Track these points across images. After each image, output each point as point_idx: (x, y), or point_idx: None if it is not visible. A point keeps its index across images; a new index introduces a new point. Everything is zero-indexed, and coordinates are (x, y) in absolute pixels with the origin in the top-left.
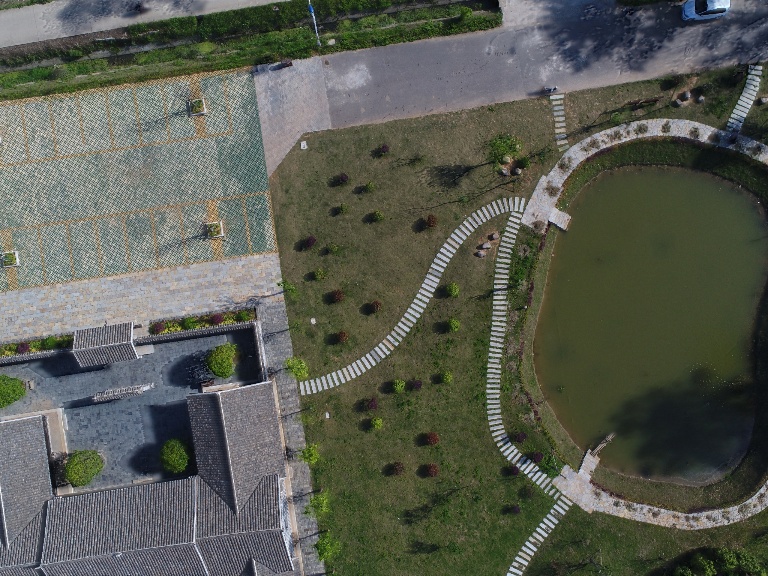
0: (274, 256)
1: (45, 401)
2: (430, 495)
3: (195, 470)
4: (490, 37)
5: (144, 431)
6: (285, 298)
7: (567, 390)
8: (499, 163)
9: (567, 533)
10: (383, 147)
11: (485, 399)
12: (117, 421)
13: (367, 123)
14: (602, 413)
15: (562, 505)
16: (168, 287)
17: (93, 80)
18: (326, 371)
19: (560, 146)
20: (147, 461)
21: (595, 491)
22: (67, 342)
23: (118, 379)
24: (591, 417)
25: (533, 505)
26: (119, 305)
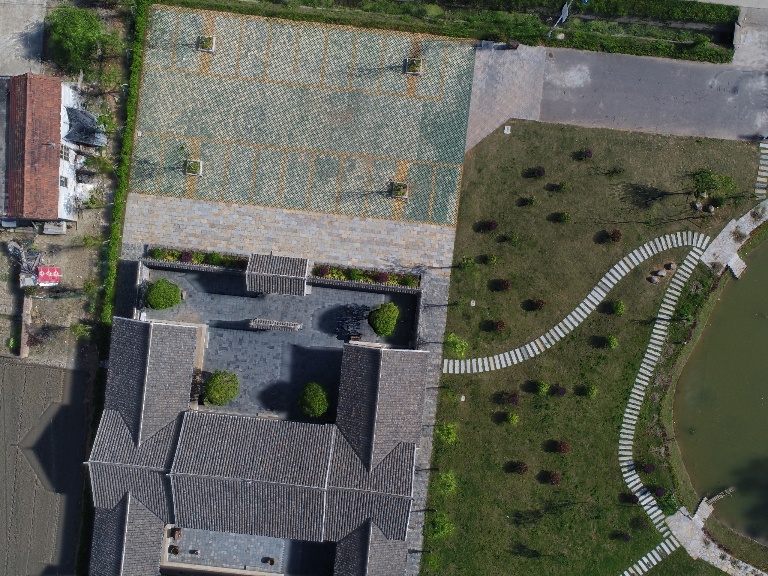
0: (451, 230)
1: (192, 314)
2: (544, 502)
3: (321, 418)
4: (717, 71)
5: (281, 368)
6: (451, 274)
7: (698, 434)
8: (694, 196)
9: (668, 573)
10: (587, 151)
11: (621, 422)
12: (257, 351)
13: (575, 124)
14: (726, 465)
15: (669, 544)
16: (340, 234)
17: (319, 14)
18: (473, 355)
19: (758, 195)
20: (277, 398)
21: (705, 539)
22: (230, 262)
23: (269, 311)
24: (715, 466)
25: (642, 537)
26: (288, 239)
